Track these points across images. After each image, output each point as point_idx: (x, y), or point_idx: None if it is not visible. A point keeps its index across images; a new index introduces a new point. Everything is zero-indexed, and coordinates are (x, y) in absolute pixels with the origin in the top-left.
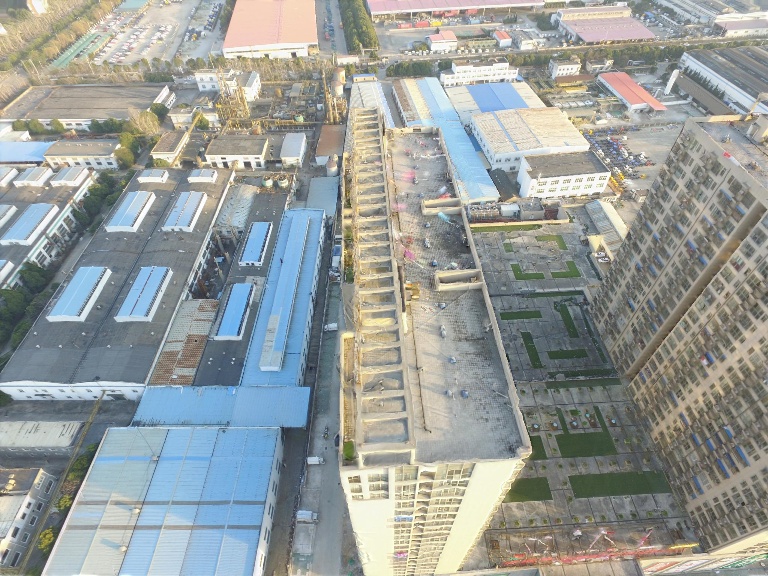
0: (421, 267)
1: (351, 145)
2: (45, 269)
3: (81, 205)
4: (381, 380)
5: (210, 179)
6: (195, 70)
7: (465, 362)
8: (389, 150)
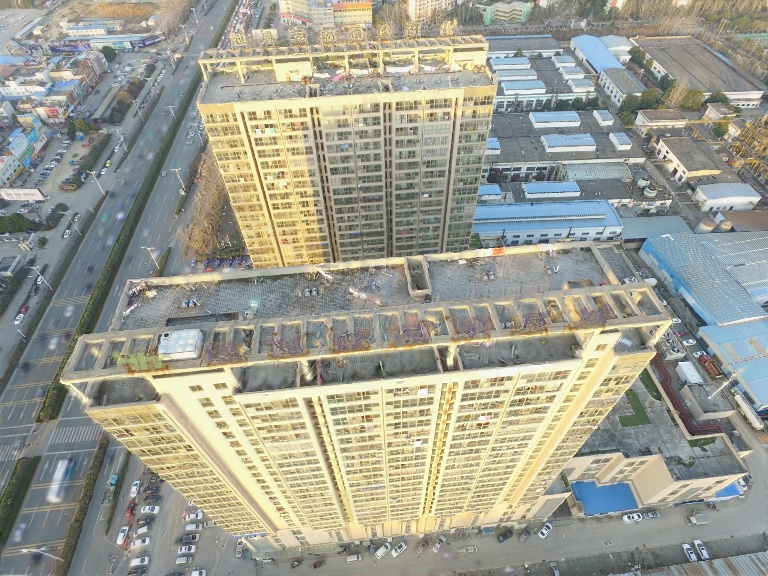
0: (328, 85)
1: (408, 27)
2: (495, 112)
3: (557, 101)
4: (251, 77)
5: (618, 145)
6: None
7: (256, 97)
8: None
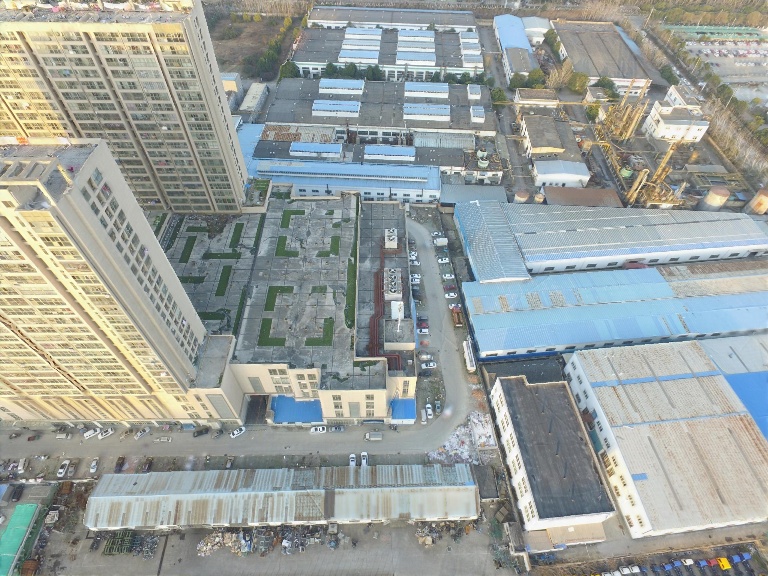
0: None
1: None
2: None
3: (445, 75)
4: None
5: None
6: (716, 97)
7: None
8: (169, 11)
